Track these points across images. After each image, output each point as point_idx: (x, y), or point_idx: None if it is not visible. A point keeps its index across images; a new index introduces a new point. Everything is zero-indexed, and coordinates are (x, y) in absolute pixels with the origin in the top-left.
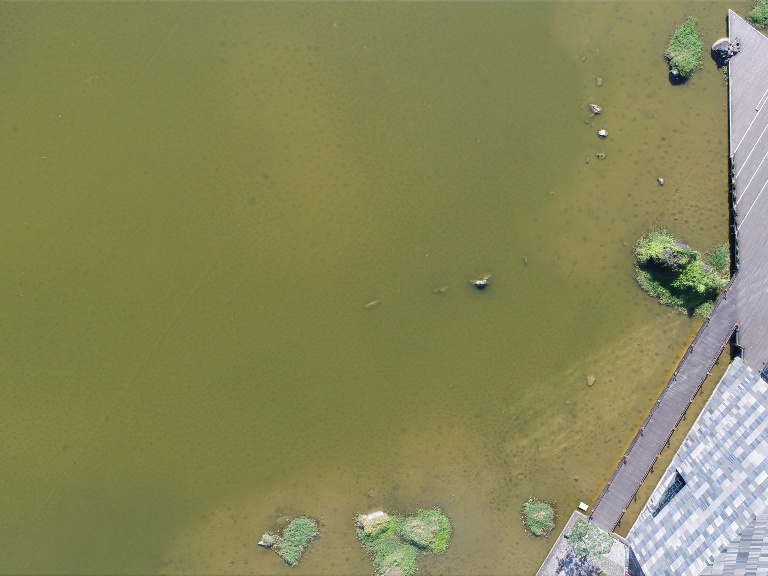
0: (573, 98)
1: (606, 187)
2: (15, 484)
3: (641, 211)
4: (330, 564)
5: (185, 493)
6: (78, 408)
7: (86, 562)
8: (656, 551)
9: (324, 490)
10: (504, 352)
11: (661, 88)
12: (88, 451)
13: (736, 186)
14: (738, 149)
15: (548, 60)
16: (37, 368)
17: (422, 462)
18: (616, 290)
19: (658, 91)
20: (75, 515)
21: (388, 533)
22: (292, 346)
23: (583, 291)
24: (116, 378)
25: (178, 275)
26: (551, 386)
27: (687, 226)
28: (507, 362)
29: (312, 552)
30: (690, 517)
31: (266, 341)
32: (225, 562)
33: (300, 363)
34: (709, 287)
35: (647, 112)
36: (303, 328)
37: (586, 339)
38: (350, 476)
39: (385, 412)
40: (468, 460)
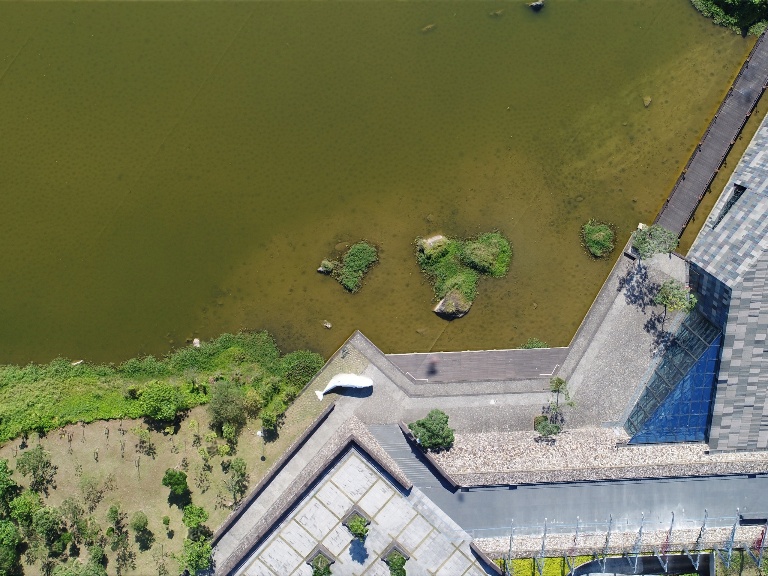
0: None
1: None
2: (69, 215)
3: None
4: (390, 290)
5: (242, 221)
6: (133, 136)
7: (142, 294)
8: (720, 250)
9: (383, 215)
10: (560, 74)
11: None
12: (143, 180)
13: None
14: None
15: None
16: (91, 96)
17: (481, 185)
18: (670, 11)
19: None
20: (131, 246)
21: (448, 257)
22: (349, 71)
23: (638, 13)
24: (171, 106)
25: (233, 1)
26: (608, 108)
27: None
28: (564, 84)
29: (372, 278)
30: (755, 209)
31: (322, 66)
32: (284, 290)
33: (357, 88)
34: (763, 0)
35: None
36: (359, 53)
37: (642, 61)
38: (409, 201)
39: (443, 136)
40: (527, 183)
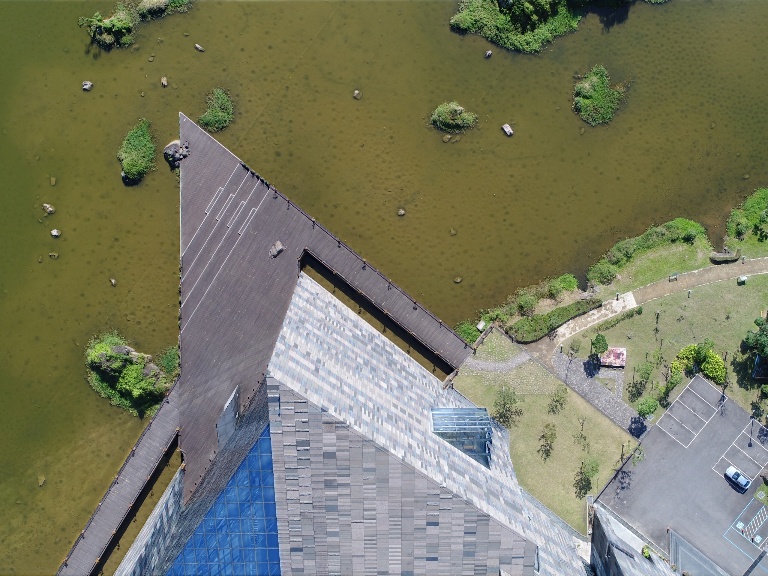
0: (27, 197)
1: (59, 287)
2: None
3: (93, 311)
4: None
5: None
6: None
7: None
8: None
9: None
10: None
11: (115, 189)
12: None
13: (182, 289)
14: (186, 252)
15: (3, 158)
16: None
17: None
18: (68, 390)
19: (112, 192)
20: None
21: None
22: None
23: (35, 390)
24: None
25: None
26: (3, 485)
27: (139, 327)
28: None
29: None
30: None
31: None
32: None
33: None
34: (148, 391)
35: (100, 212)
36: None
37: (38, 439)
38: None
39: None
40: None
